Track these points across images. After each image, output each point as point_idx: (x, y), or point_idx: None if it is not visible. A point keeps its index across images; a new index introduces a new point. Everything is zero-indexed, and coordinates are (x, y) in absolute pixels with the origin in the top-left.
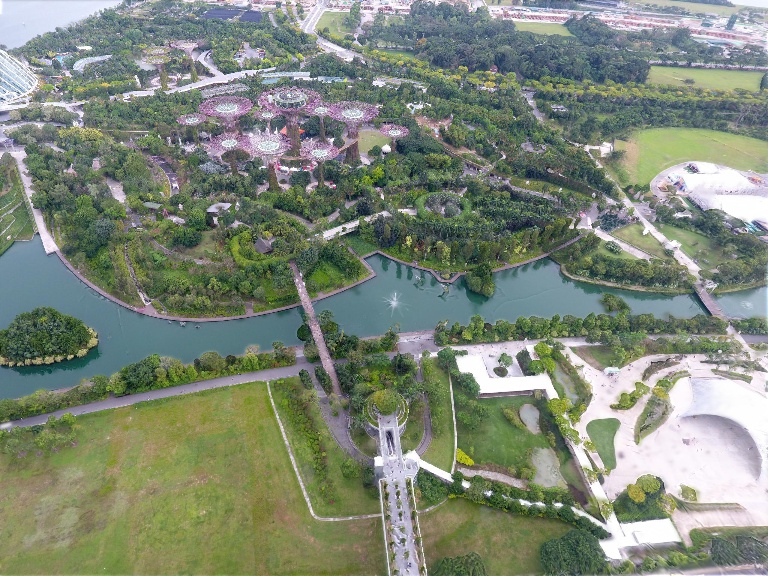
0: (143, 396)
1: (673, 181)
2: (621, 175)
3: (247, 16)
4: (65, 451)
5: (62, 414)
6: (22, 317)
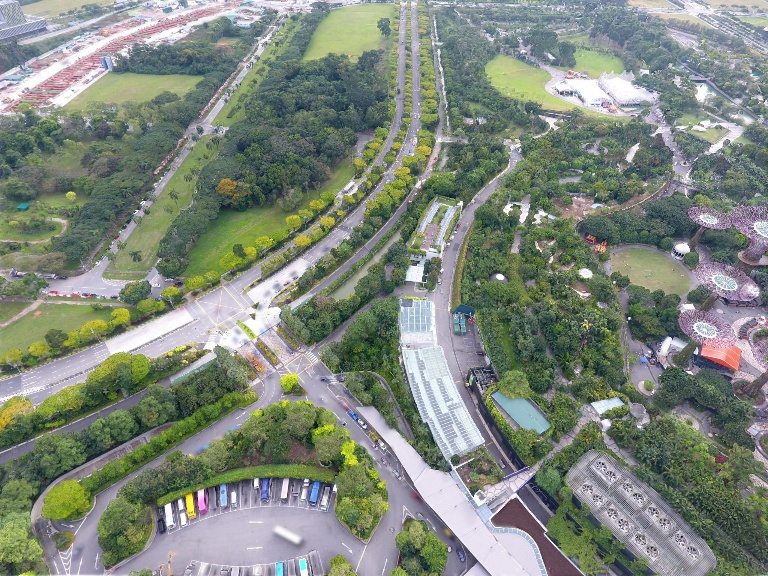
0: None
1: (599, 104)
2: (609, 121)
3: None
4: None
5: None
6: None
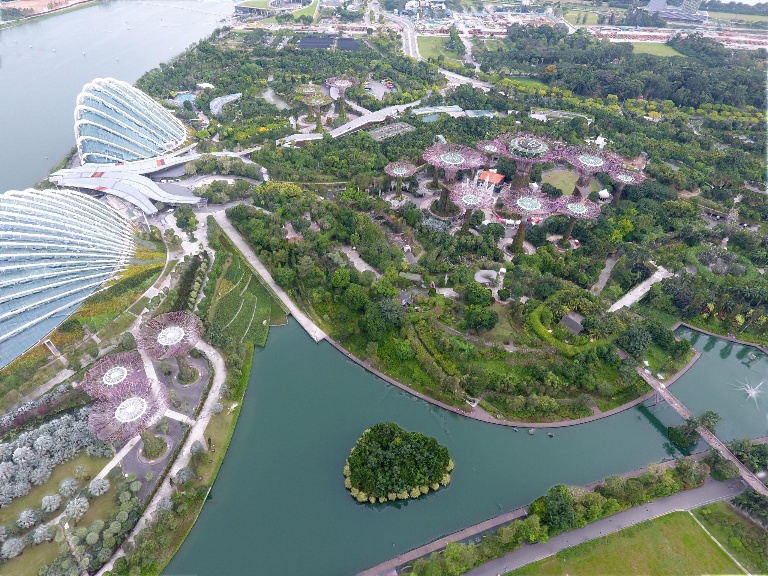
0: (560, 541)
1: None
2: None
3: (344, 44)
4: None
5: (482, 574)
6: (370, 438)
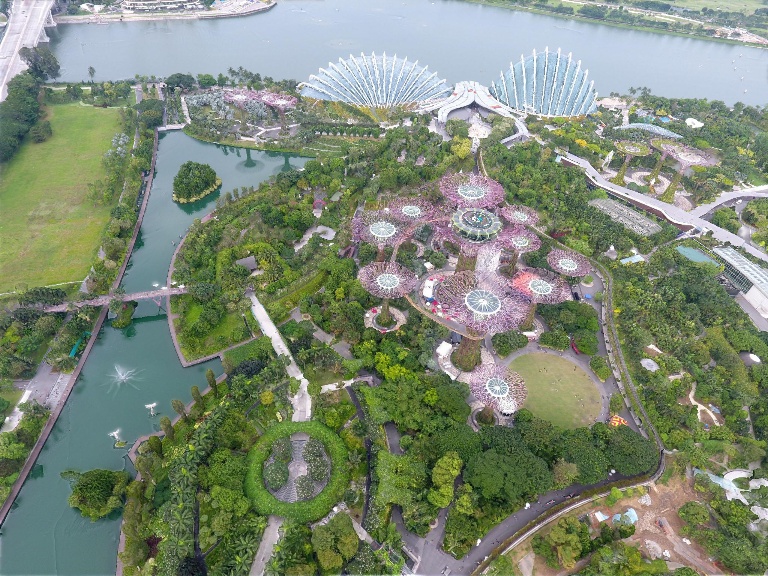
0: None
1: None
2: None
3: None
4: (93, 205)
5: None
6: (205, 166)
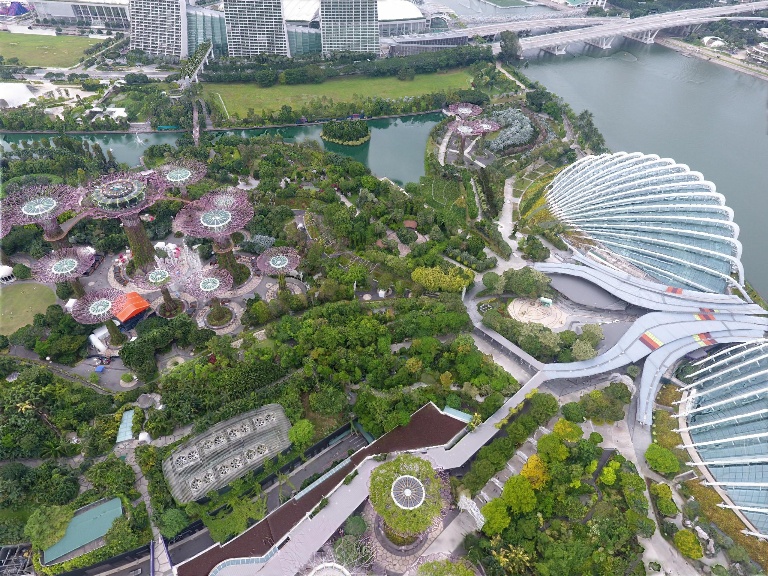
0: None
1: None
2: None
3: None
4: None
5: None
6: None
